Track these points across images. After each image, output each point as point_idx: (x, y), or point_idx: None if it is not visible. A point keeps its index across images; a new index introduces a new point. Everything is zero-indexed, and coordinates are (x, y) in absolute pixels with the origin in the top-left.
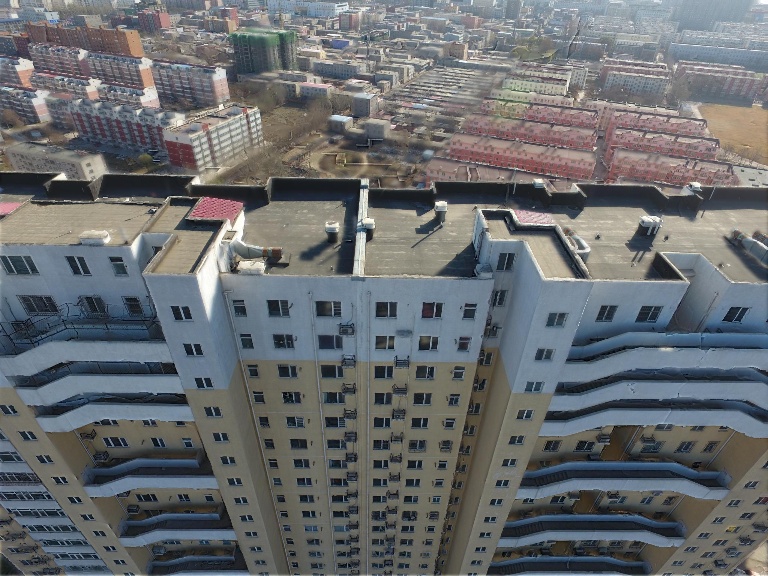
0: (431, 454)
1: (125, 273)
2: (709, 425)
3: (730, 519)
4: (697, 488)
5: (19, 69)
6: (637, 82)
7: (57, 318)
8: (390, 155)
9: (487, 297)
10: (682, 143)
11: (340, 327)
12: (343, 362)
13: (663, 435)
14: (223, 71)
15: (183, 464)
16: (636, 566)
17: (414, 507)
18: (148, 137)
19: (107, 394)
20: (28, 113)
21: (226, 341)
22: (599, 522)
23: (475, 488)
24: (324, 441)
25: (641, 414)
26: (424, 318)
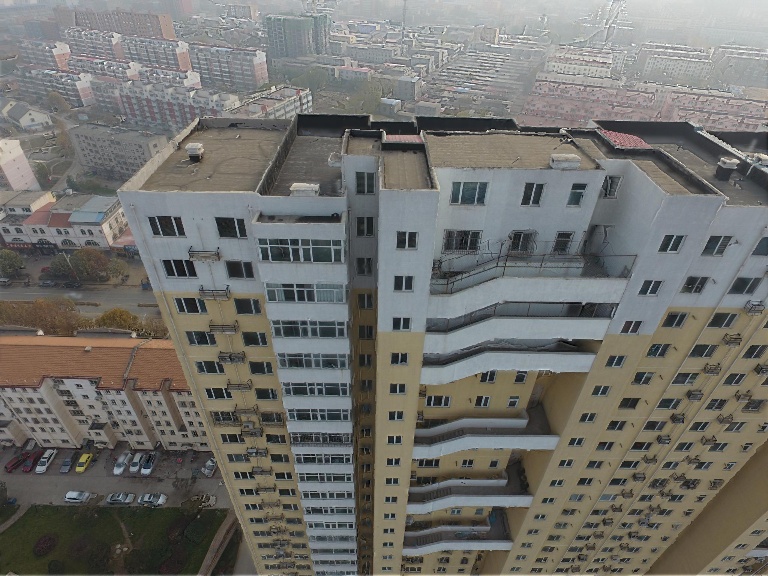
0: (762, 415)
1: (576, 204)
2: None
3: None
4: None
5: (56, 53)
6: (679, 66)
7: (471, 257)
8: None
9: None
10: (749, 124)
11: None
12: (752, 308)
13: None
14: (263, 54)
15: (510, 424)
16: None
17: (701, 474)
18: None
19: (500, 342)
20: (71, 97)
21: None
22: None
23: None
24: (660, 400)
25: None
26: None
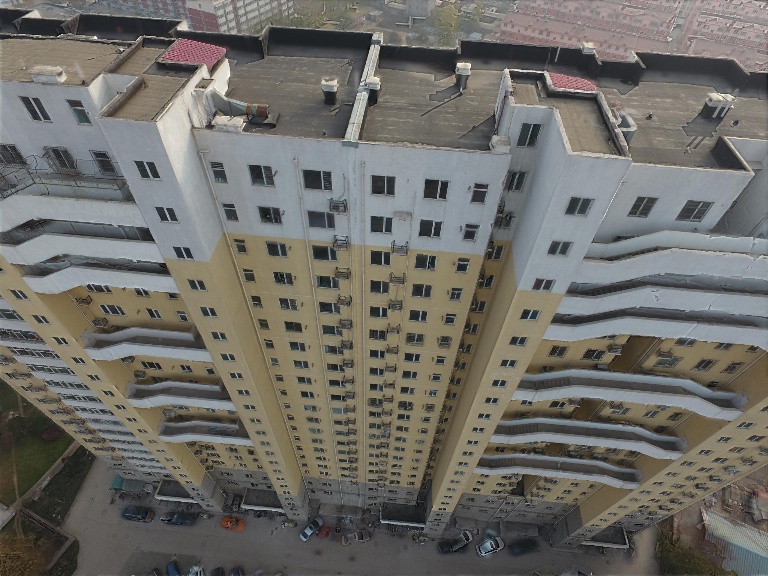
0: (429, 349)
1: (88, 122)
2: (738, 343)
3: (737, 440)
4: (708, 407)
5: None
6: None
7: (27, 172)
8: (432, 37)
9: (501, 177)
10: None
11: (330, 202)
12: (335, 243)
13: (682, 351)
14: None
15: (179, 336)
16: (628, 472)
17: (410, 398)
18: (170, 4)
19: (89, 258)
20: None
21: (205, 209)
22: (597, 429)
23: (472, 386)
24: (319, 326)
25: (661, 325)
26: (426, 198)
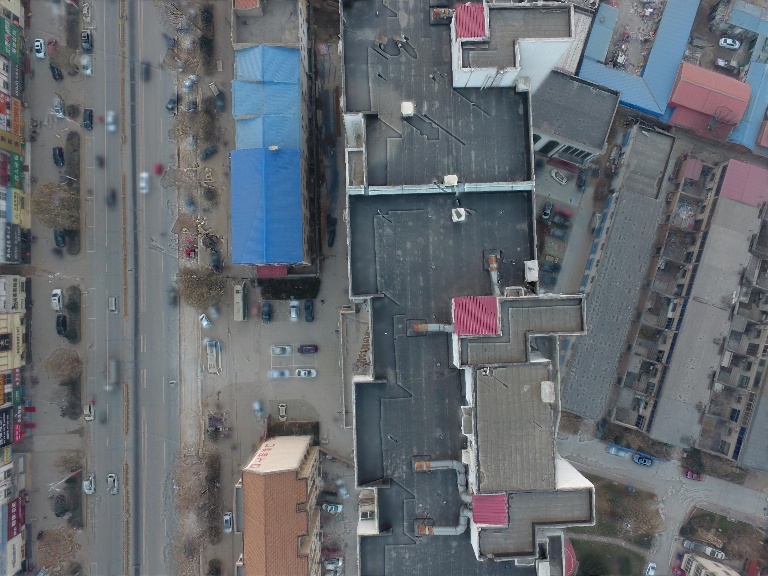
0: None
1: None
2: None
3: None
4: None
5: None
6: None
7: None
8: None
9: None
10: None
11: None
12: None
13: None
14: None
15: None
16: None
17: None
18: None
19: None
20: None
21: None
22: None
23: None
24: None
25: None
26: None
